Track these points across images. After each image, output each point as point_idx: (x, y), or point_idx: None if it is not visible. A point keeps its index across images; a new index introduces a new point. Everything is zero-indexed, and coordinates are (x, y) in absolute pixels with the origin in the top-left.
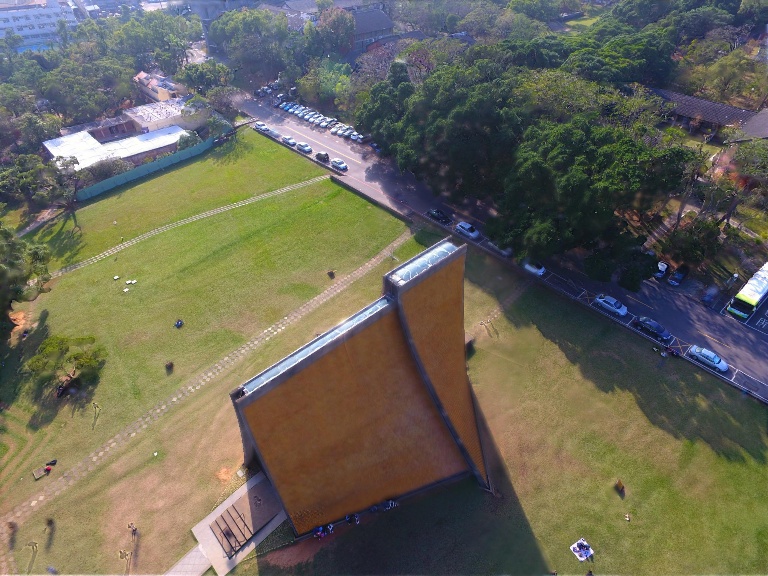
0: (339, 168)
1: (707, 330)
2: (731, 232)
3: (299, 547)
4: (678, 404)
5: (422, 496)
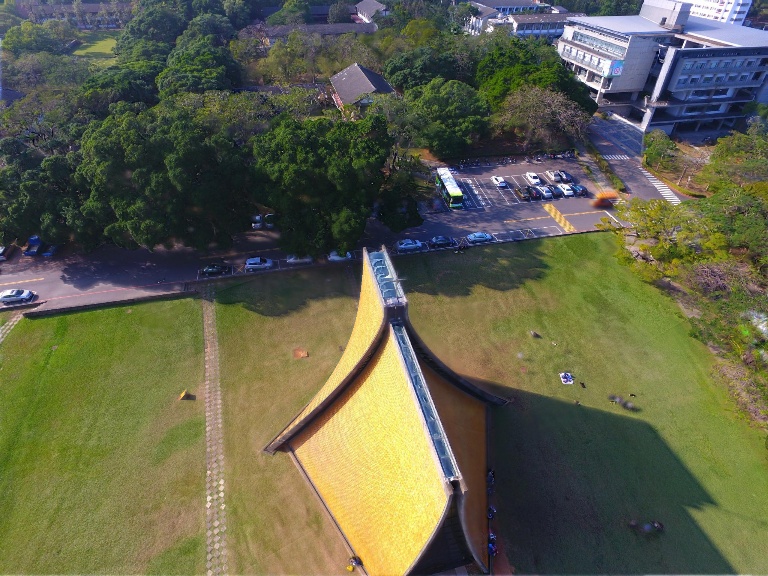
0: (22, 300)
1: (458, 224)
2: (418, 160)
3: (498, 575)
4: (498, 271)
5: (493, 449)
